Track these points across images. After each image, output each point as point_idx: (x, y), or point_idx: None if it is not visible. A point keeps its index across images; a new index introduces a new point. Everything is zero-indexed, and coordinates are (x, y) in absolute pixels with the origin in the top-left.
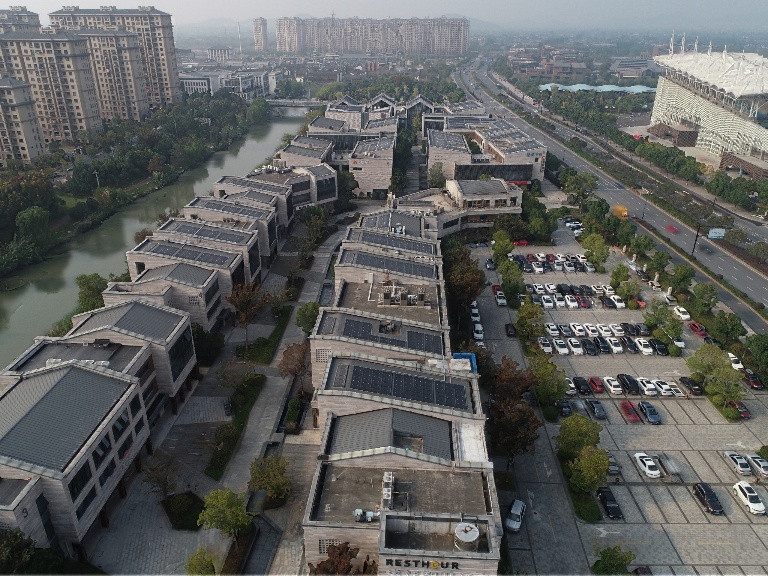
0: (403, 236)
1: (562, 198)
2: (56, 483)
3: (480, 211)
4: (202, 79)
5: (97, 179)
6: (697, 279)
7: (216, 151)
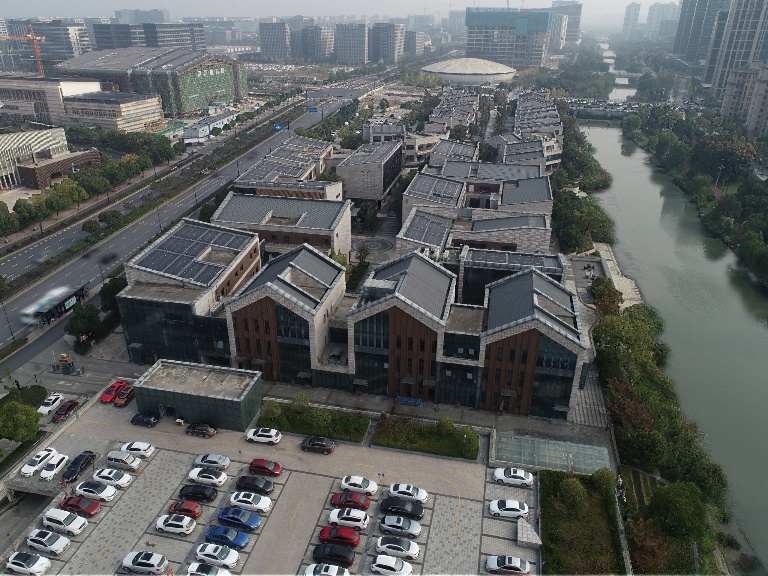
0: None
1: None
2: None
3: None
4: None
5: None
6: None
7: None
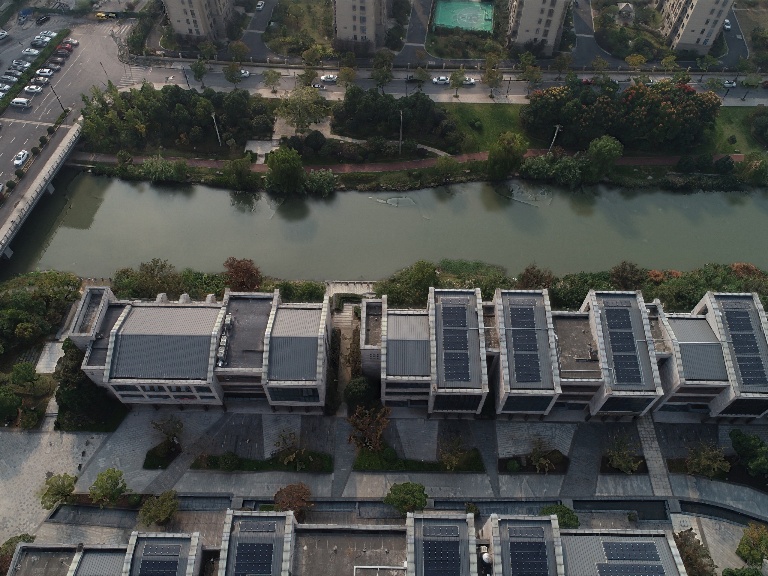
0: None
1: None
2: None
3: None
4: None
5: None
6: None
7: None
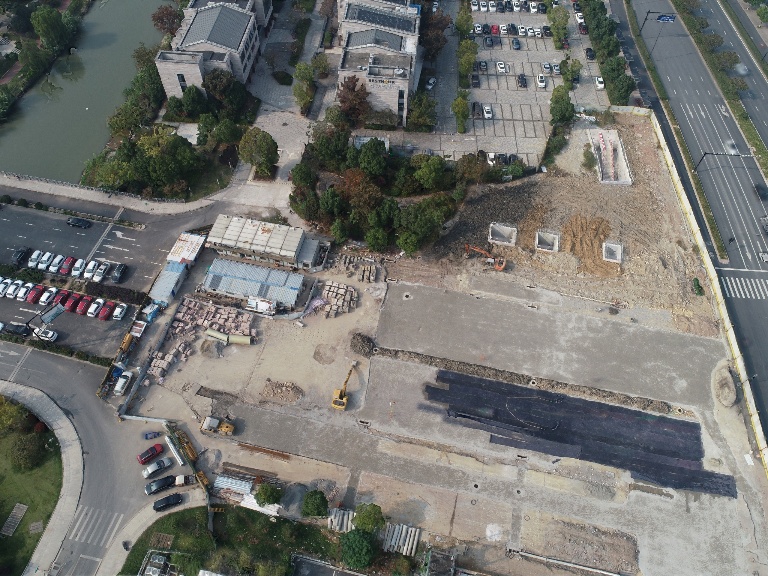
0: None
1: None
2: (236, 55)
3: None
4: None
5: None
6: None
7: None
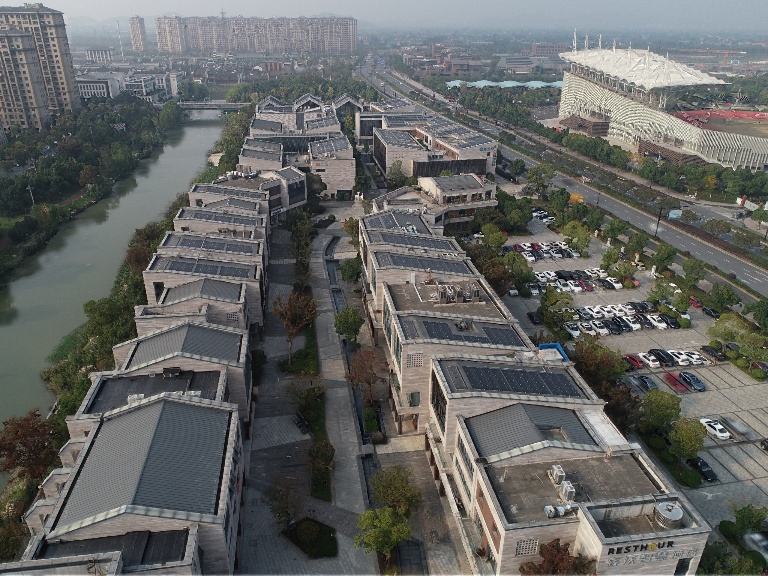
0: (418, 235)
1: (516, 189)
2: (215, 528)
3: (460, 206)
4: (99, 82)
5: (31, 195)
6: None
7: (141, 159)
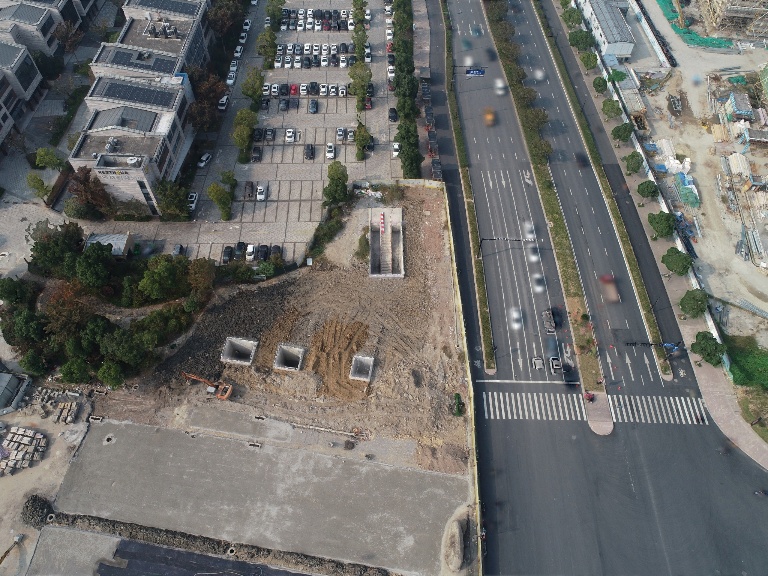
0: None
1: None
2: None
3: None
4: None
5: None
6: (429, 2)
7: None
